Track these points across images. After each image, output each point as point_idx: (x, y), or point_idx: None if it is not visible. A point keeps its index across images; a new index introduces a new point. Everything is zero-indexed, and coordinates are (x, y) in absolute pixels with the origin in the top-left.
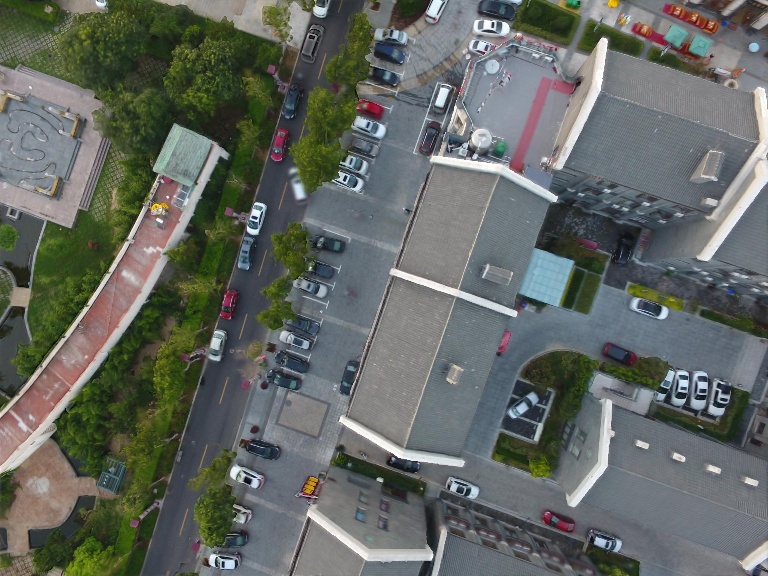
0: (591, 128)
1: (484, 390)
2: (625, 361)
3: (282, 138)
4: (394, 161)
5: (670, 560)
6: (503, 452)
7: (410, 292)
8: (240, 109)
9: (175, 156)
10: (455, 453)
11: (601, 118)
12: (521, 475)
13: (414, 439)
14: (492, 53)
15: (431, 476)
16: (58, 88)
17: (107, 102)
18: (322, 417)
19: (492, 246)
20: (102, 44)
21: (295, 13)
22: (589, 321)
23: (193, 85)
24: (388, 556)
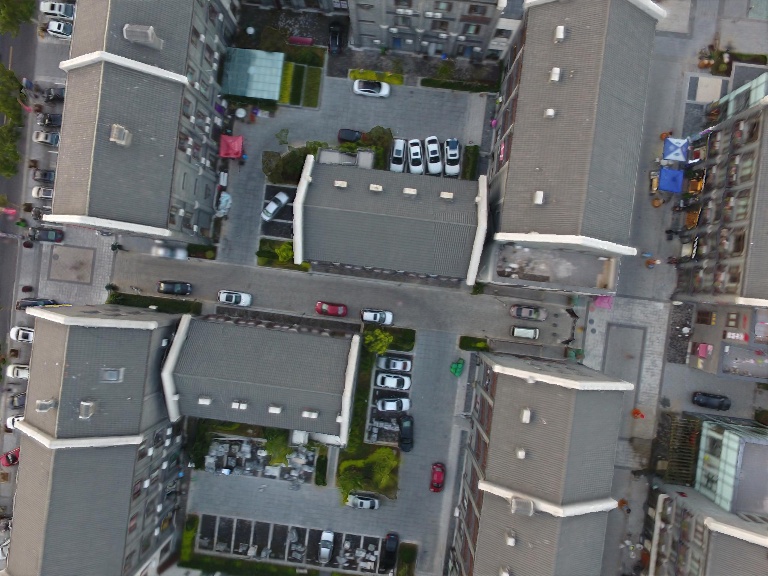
0: None
1: (238, 202)
2: None
3: None
4: None
5: (443, 322)
6: (262, 253)
7: (78, 78)
8: None
9: None
10: (158, 225)
11: None
12: (289, 275)
13: (98, 207)
14: None
15: (205, 295)
16: None
17: None
18: (90, 263)
19: (135, 11)
20: None
21: None
22: (321, 114)
23: None
24: (91, 321)
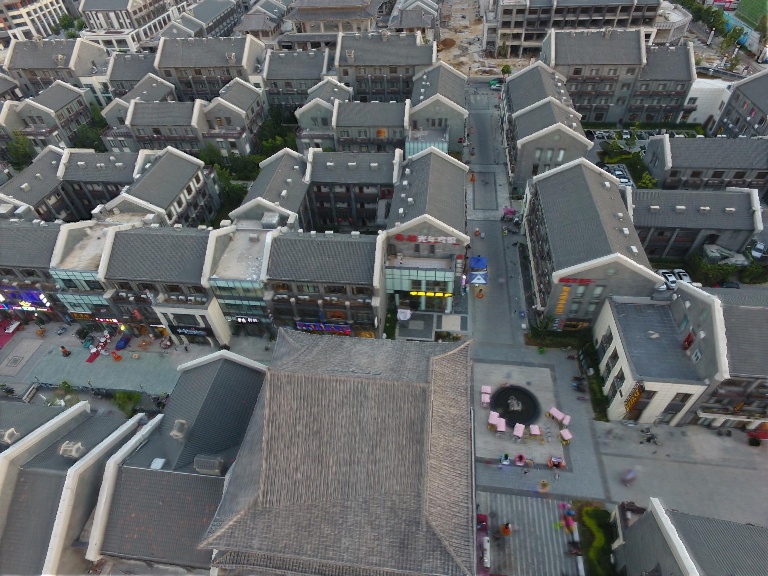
0: None
1: None
2: (720, 283)
3: None
4: None
5: None
6: None
7: None
8: None
9: None
10: None
11: None
12: None
13: None
14: None
15: None
16: None
17: None
18: None
19: None
20: None
21: None
22: None
23: None
24: None
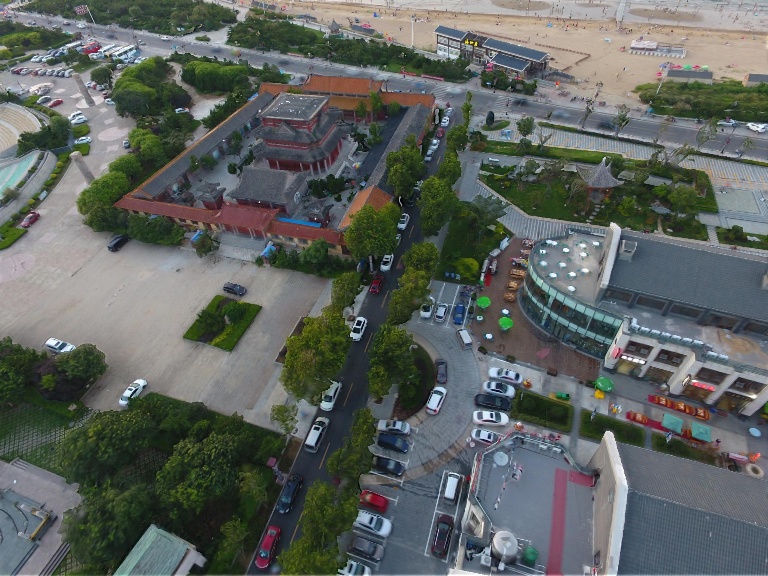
0: (632, 531)
1: None
2: None
3: (272, 538)
4: (402, 566)
5: None
6: None
7: None
8: (231, 502)
9: (138, 568)
10: None
11: (640, 519)
12: None
13: None
14: (498, 445)
15: None
16: (44, 482)
17: (87, 499)
18: None
19: None
20: (107, 440)
21: (303, 407)
22: None
23: (186, 480)
24: None
